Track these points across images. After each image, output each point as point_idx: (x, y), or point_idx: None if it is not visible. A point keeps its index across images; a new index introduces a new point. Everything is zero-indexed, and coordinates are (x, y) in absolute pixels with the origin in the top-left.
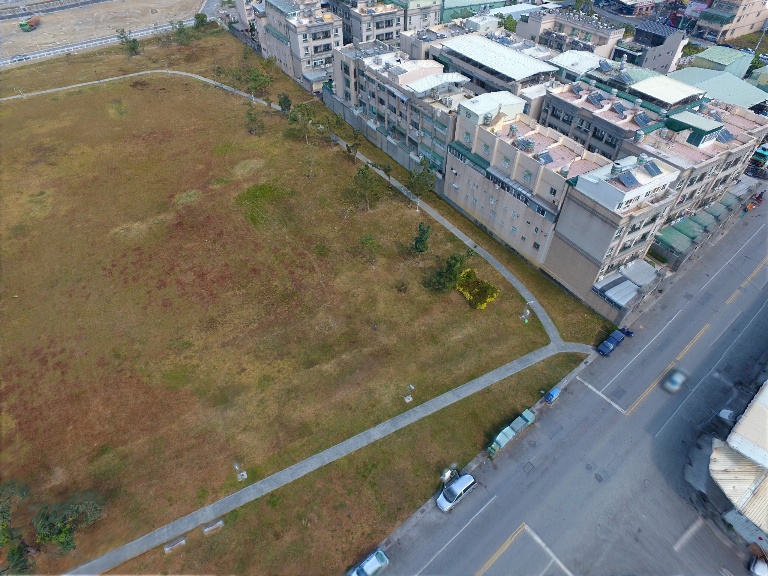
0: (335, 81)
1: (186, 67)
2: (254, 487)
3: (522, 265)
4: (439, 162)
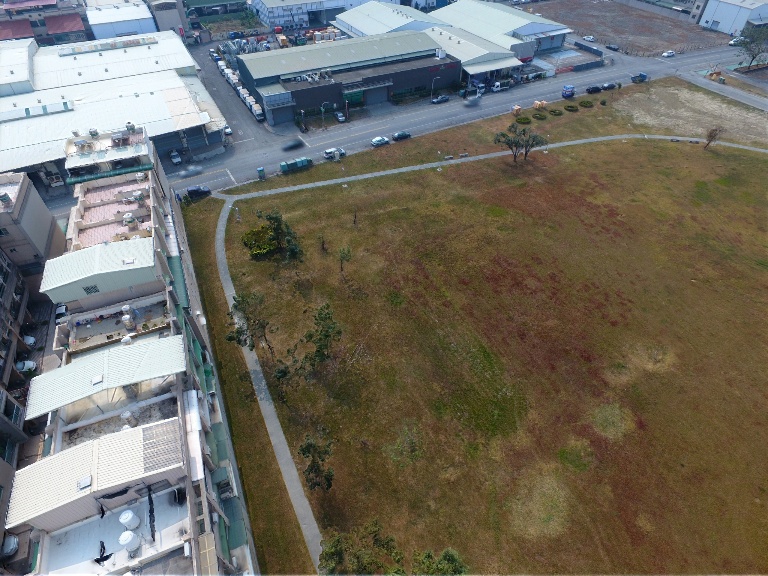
0: None
1: None
2: (433, 166)
3: (199, 260)
4: None
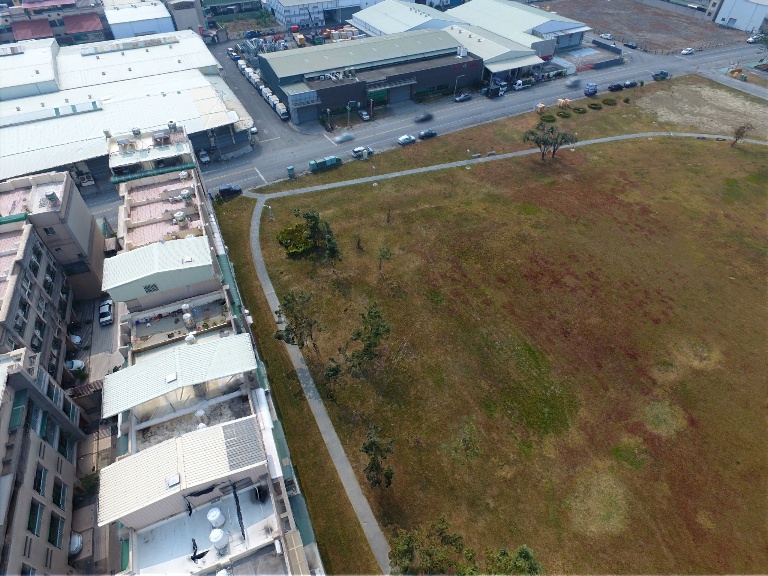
0: None
1: None
2: (461, 164)
3: (236, 259)
4: None
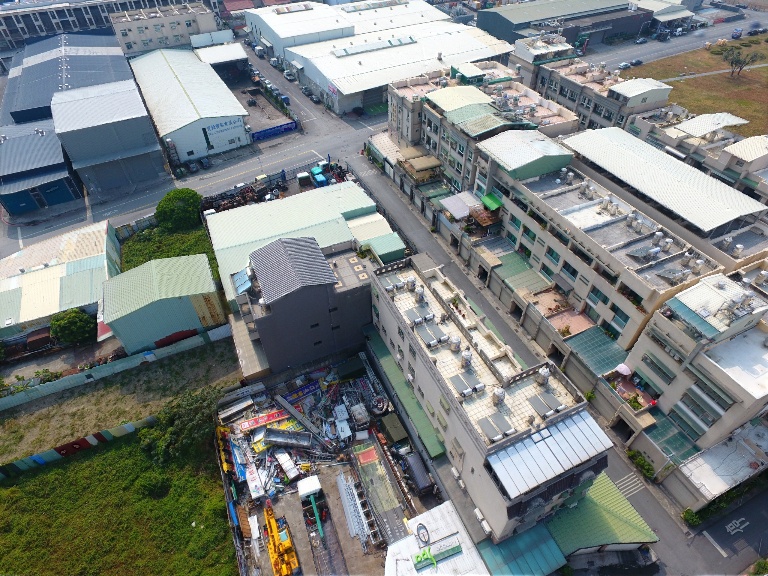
0: None
1: None
2: None
3: None
4: None
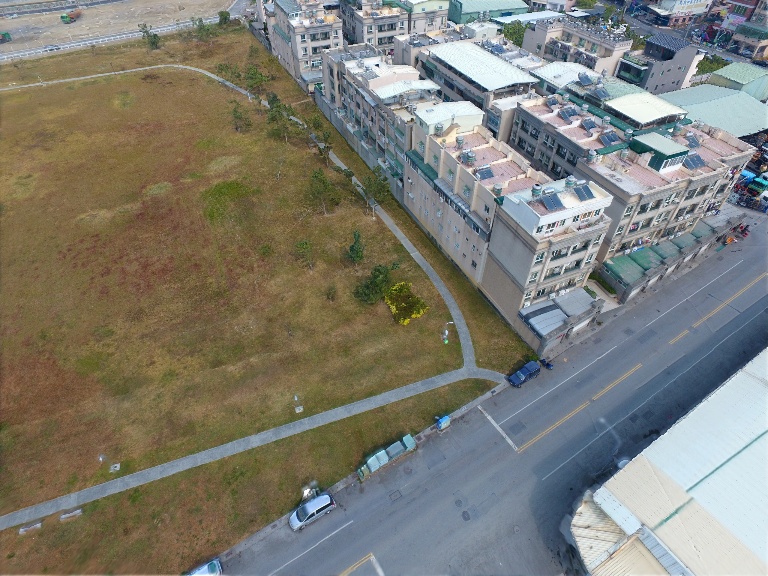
0: (324, 83)
1: (198, 63)
2: (122, 480)
3: (462, 283)
4: (400, 170)
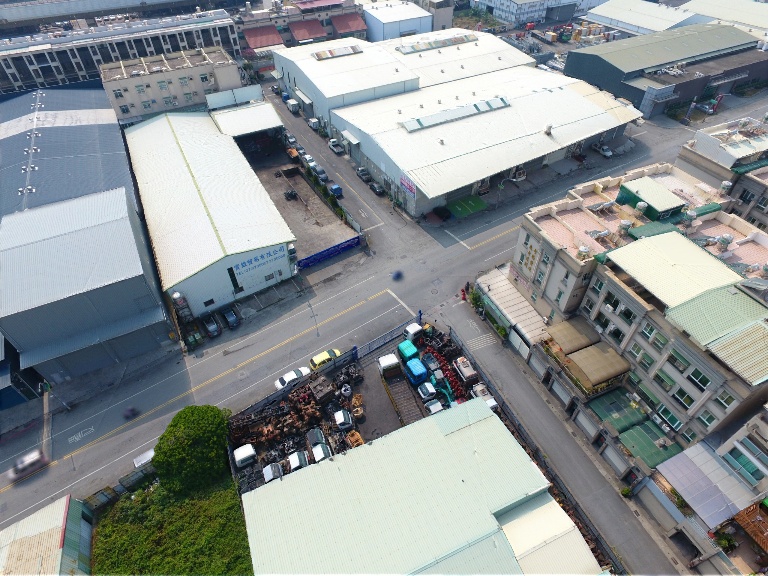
0: None
1: None
2: None
3: None
4: None
